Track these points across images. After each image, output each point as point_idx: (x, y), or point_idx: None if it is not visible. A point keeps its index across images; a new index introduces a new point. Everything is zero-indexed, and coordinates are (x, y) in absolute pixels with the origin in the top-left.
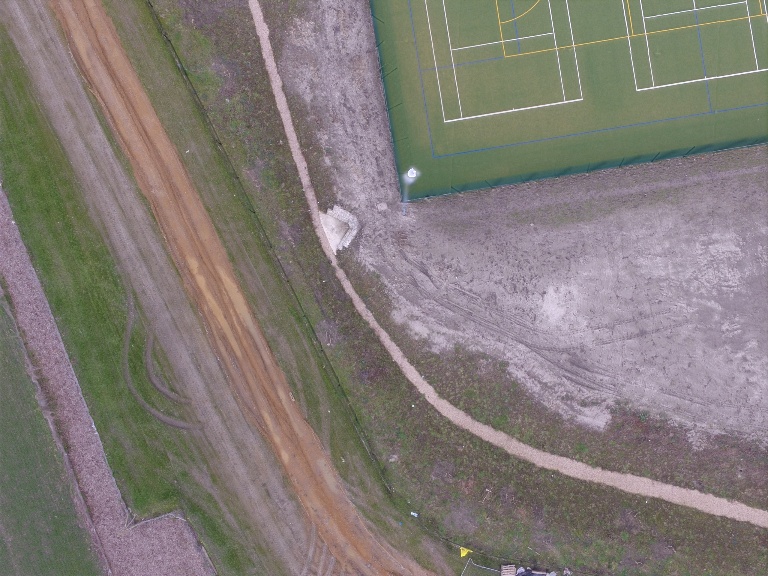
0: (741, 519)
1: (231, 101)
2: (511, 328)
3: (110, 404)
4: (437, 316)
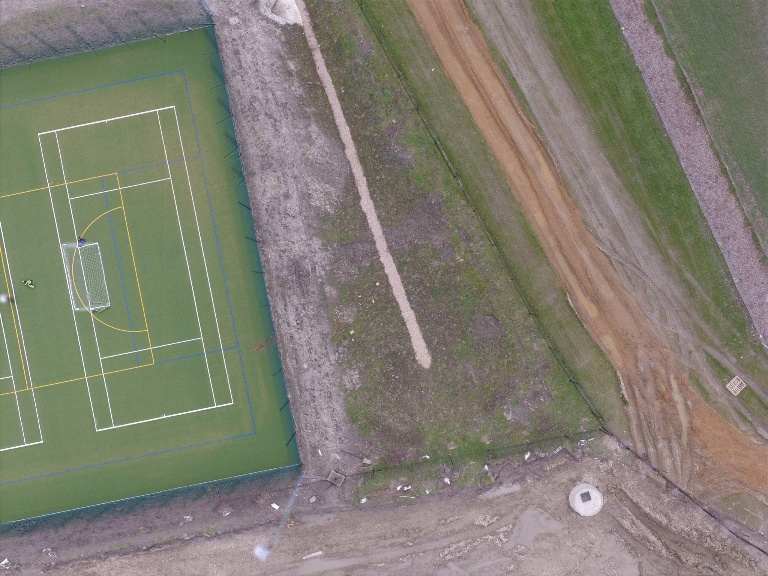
0: None
1: (390, 120)
2: None
3: None
4: None
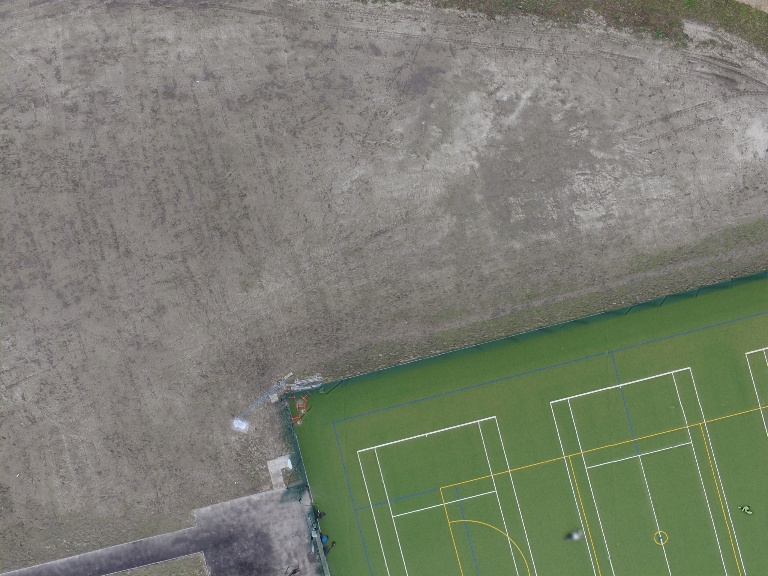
0: None
1: None
2: None
3: None
4: None
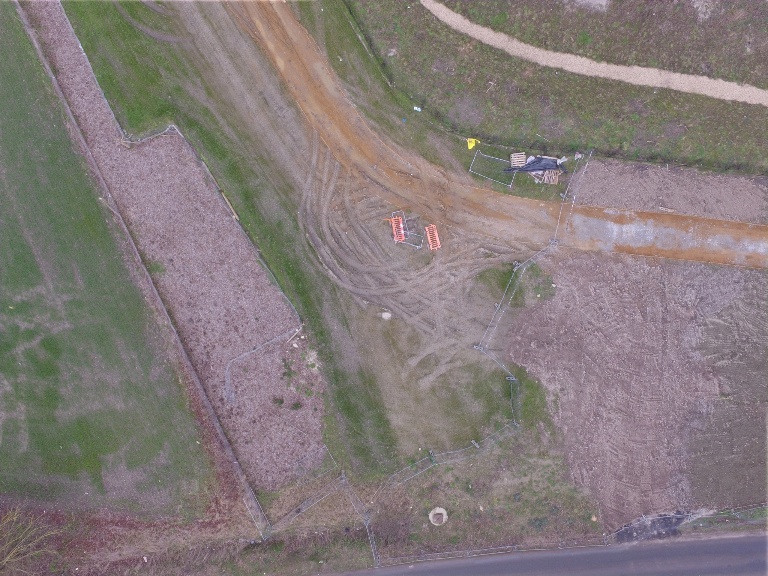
0: (753, 102)
1: None
2: None
3: (95, 23)
4: None
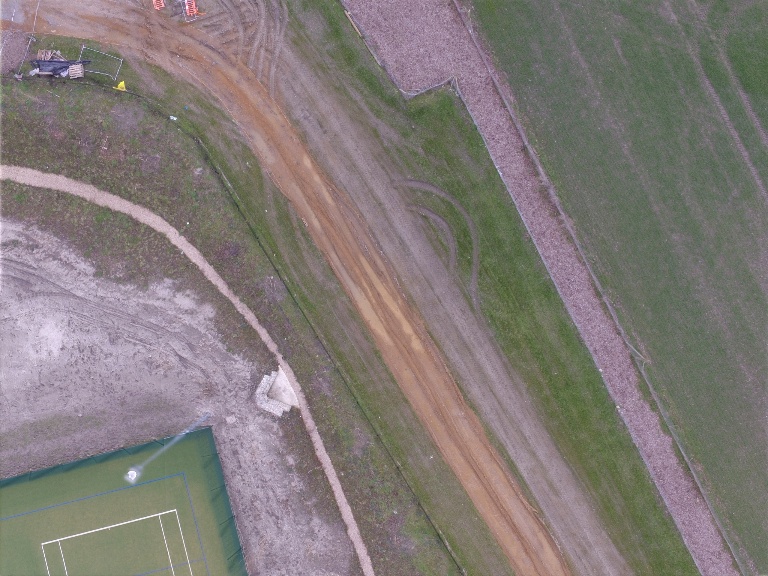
0: None
1: (392, 512)
2: (92, 311)
3: (486, 197)
4: (166, 316)
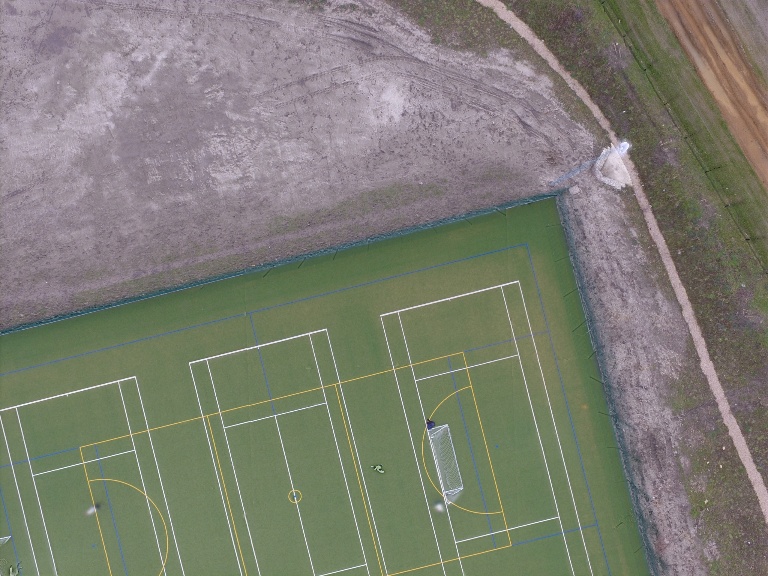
0: None
1: (740, 285)
2: (434, 76)
3: None
4: (510, 81)
